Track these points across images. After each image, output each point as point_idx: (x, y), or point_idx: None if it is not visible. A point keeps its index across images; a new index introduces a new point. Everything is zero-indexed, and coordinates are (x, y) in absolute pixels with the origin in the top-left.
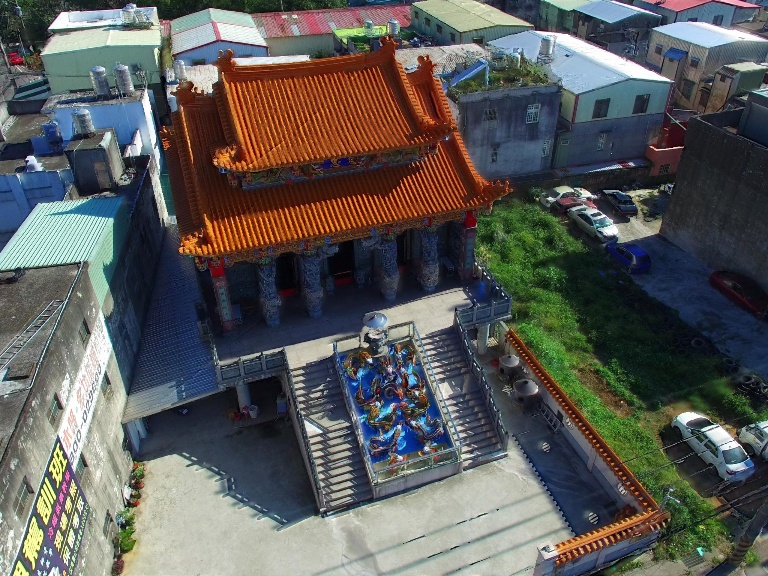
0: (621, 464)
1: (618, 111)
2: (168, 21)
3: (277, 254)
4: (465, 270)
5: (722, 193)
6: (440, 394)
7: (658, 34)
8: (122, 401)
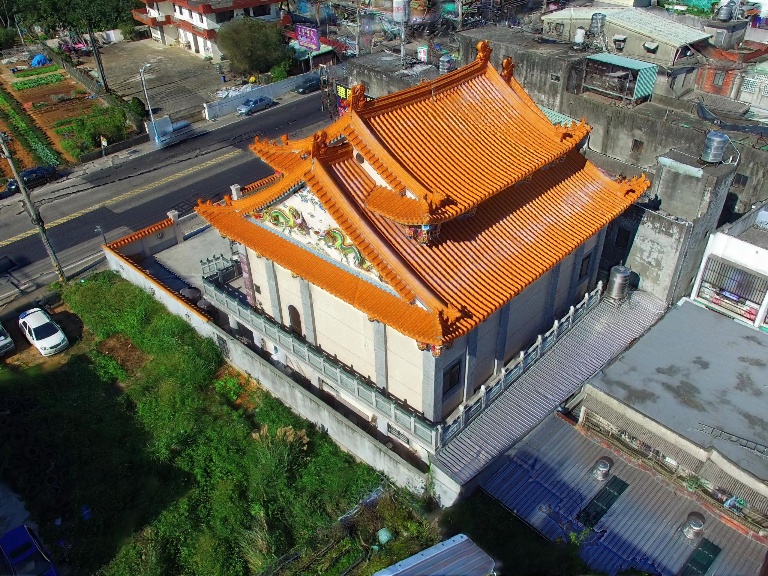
0: None
1: None
2: None
3: None
4: None
5: None
6: None
7: None
8: None
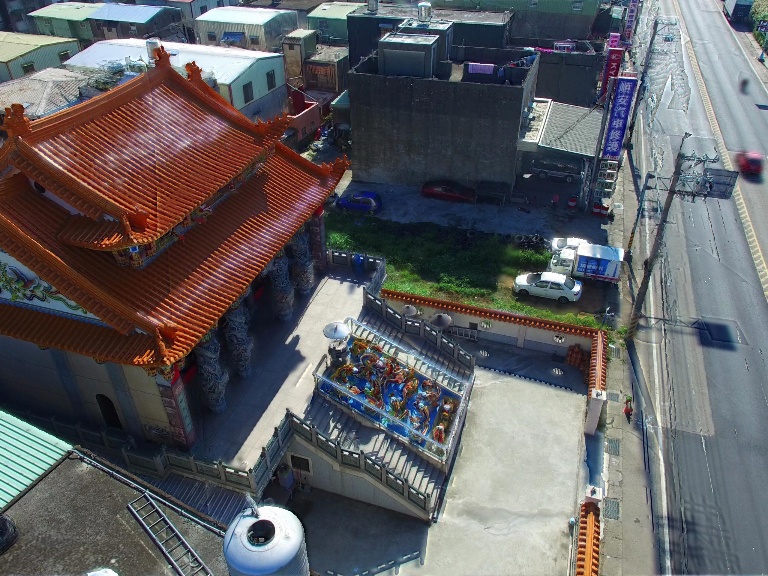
0: (553, 322)
1: (258, 92)
2: None
3: None
4: (323, 259)
5: (399, 125)
6: None
7: (205, 23)
8: None
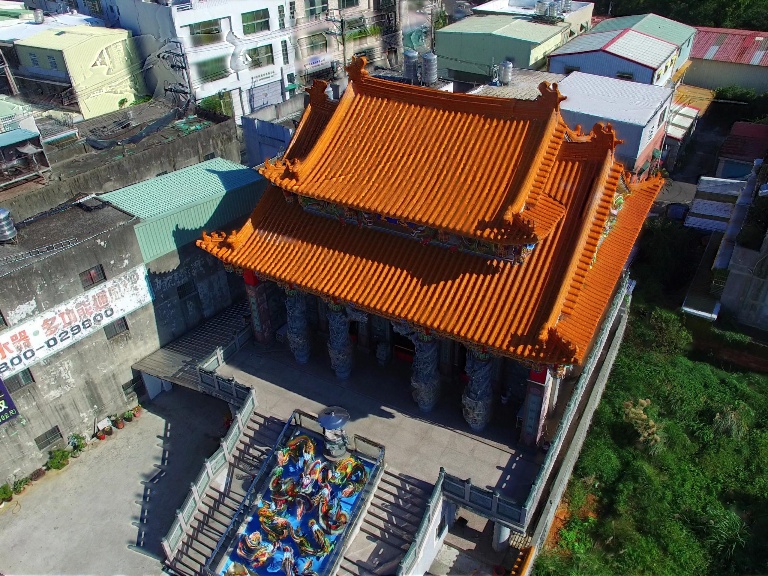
0: None
1: None
2: (600, 20)
3: (305, 291)
4: (525, 431)
5: None
6: (350, 550)
7: None
8: (147, 349)
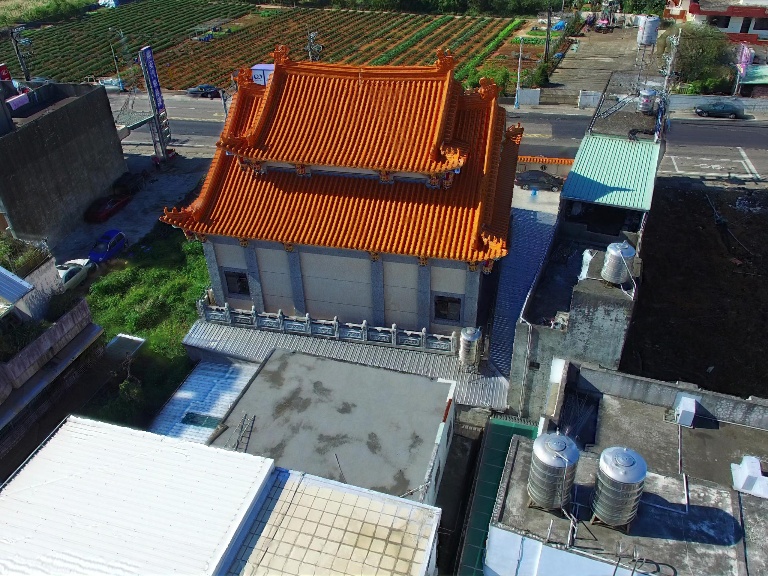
0: None
1: None
2: None
3: None
4: None
5: None
6: None
7: None
8: None
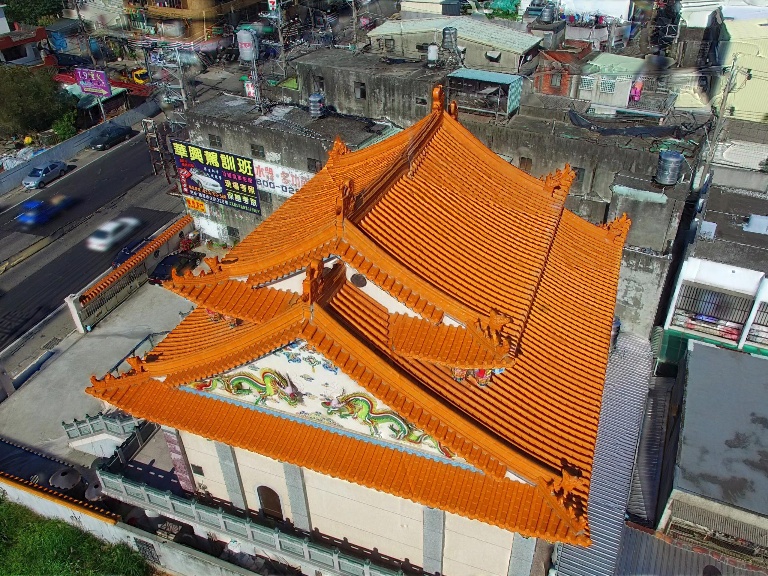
0: None
1: None
2: None
3: None
4: None
5: None
6: None
7: None
8: None
